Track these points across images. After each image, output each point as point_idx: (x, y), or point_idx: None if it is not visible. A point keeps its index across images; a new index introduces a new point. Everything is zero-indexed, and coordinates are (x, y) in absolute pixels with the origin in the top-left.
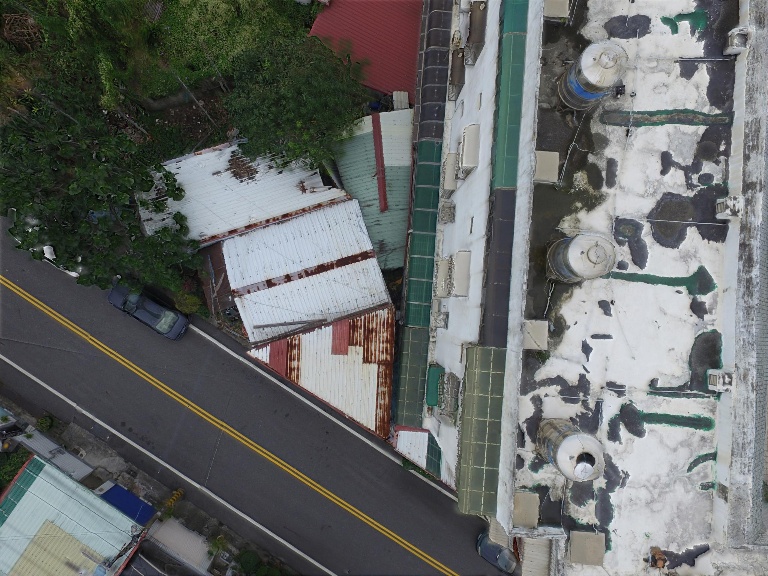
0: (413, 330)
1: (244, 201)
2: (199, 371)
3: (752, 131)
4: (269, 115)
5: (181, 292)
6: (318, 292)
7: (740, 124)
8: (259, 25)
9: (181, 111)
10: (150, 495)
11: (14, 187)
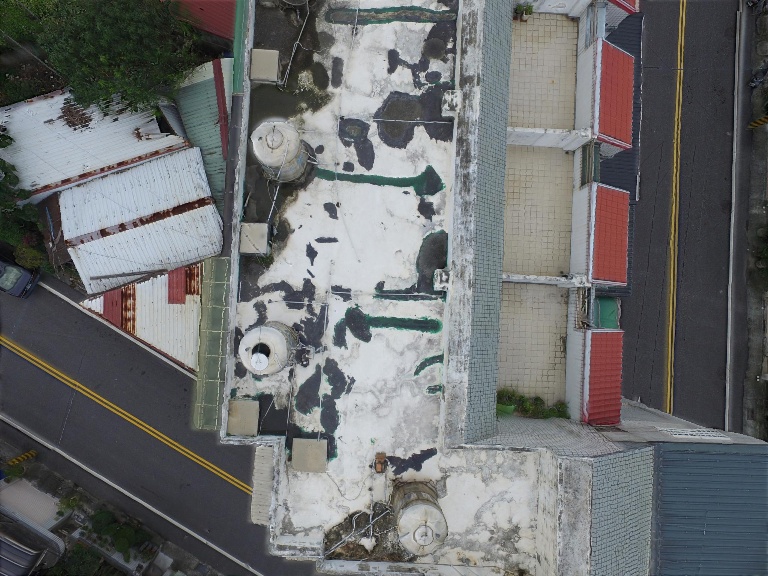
0: None
1: (77, 149)
2: (50, 330)
3: (470, 24)
4: (67, 48)
5: (19, 246)
6: (156, 241)
7: (460, 18)
8: None
9: (33, 65)
10: (0, 458)
11: None
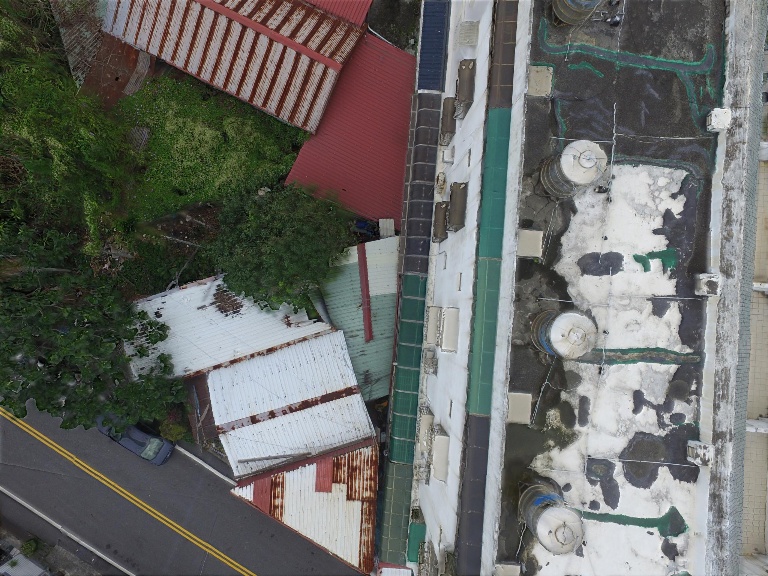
0: (397, 466)
1: (229, 335)
2: (185, 492)
3: (722, 379)
4: (251, 279)
5: (166, 422)
6: (302, 427)
7: (711, 370)
8: (246, 151)
9: (168, 226)
10: None
11: None
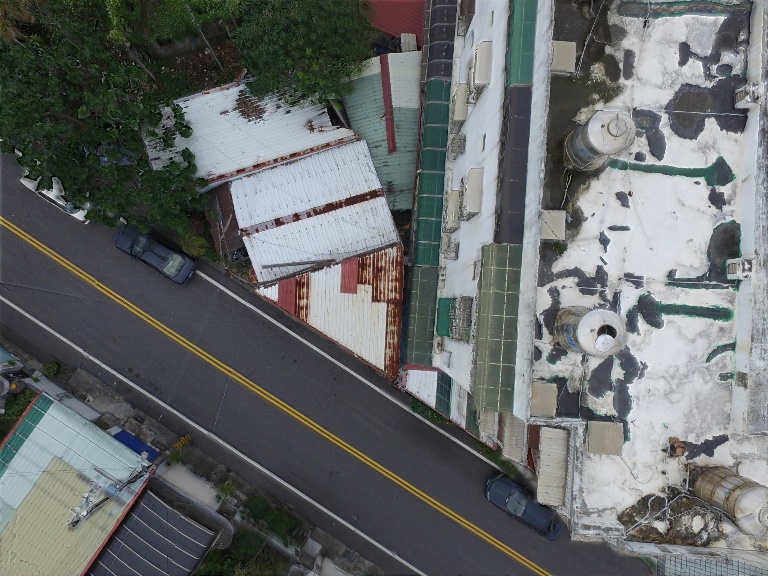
0: (422, 269)
1: (252, 140)
2: (206, 317)
3: None
4: (279, 41)
5: (189, 234)
6: (327, 231)
7: (759, 11)
8: None
9: (187, 59)
10: (158, 441)
11: (23, 108)
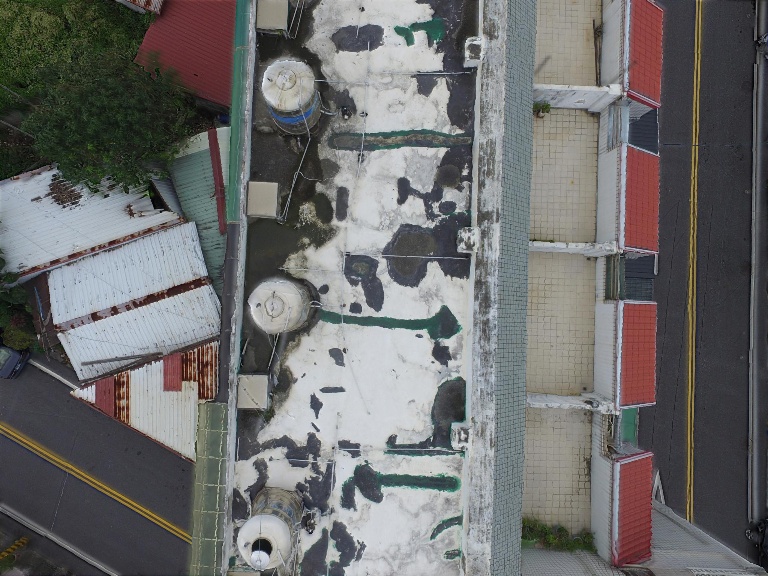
0: None
1: (67, 228)
2: (41, 410)
3: (488, 153)
4: (52, 138)
5: (7, 328)
6: (150, 324)
7: (476, 146)
8: (88, 37)
9: None
10: None
11: None
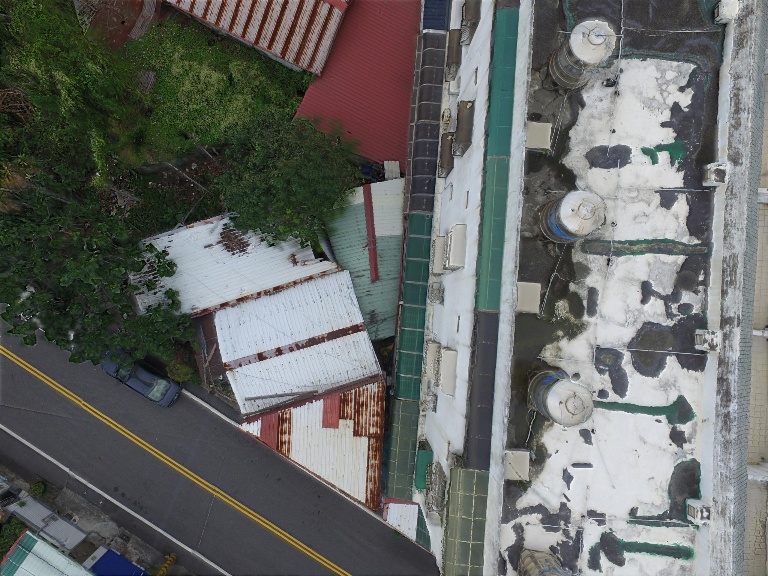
0: (403, 403)
1: (236, 274)
2: (192, 436)
3: (730, 266)
4: (259, 204)
5: (173, 362)
6: (309, 364)
7: (719, 258)
8: (251, 94)
9: (174, 174)
10: (143, 560)
11: (5, 282)
